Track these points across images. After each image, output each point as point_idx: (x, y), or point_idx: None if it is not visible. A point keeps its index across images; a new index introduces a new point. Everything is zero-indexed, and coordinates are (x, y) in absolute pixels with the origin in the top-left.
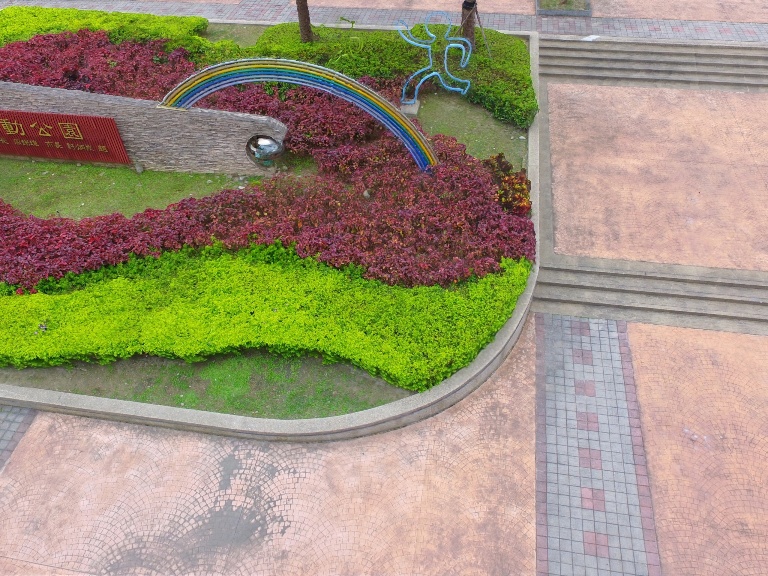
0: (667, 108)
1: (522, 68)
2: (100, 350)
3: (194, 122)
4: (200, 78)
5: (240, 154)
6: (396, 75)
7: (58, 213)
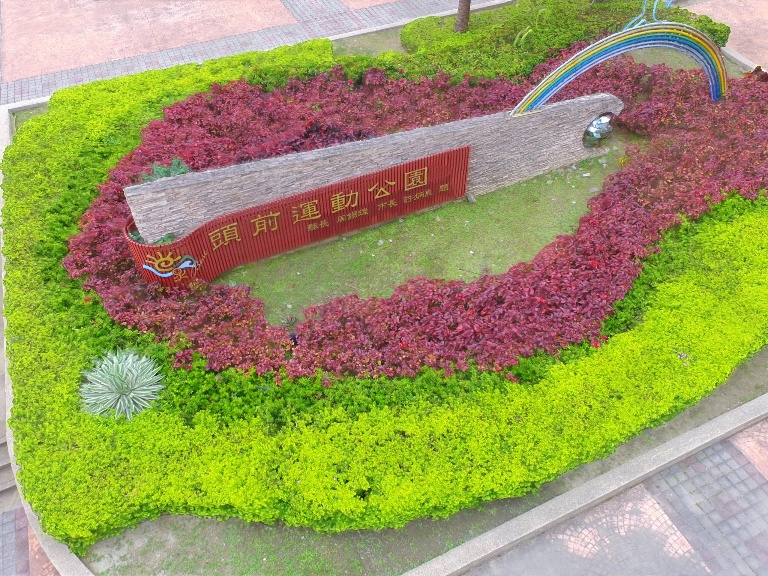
0: (746, 10)
1: (661, 3)
2: (755, 345)
3: (546, 121)
4: (564, 69)
5: (576, 142)
6: (585, 36)
7: (465, 271)
